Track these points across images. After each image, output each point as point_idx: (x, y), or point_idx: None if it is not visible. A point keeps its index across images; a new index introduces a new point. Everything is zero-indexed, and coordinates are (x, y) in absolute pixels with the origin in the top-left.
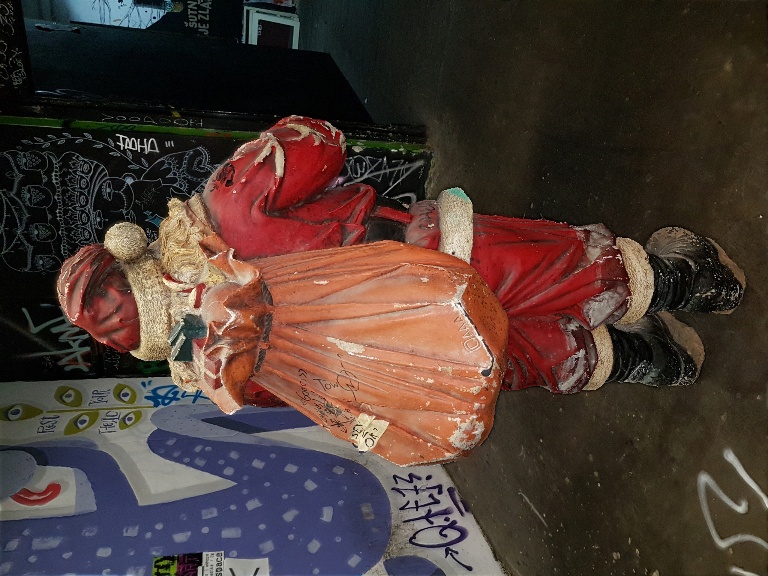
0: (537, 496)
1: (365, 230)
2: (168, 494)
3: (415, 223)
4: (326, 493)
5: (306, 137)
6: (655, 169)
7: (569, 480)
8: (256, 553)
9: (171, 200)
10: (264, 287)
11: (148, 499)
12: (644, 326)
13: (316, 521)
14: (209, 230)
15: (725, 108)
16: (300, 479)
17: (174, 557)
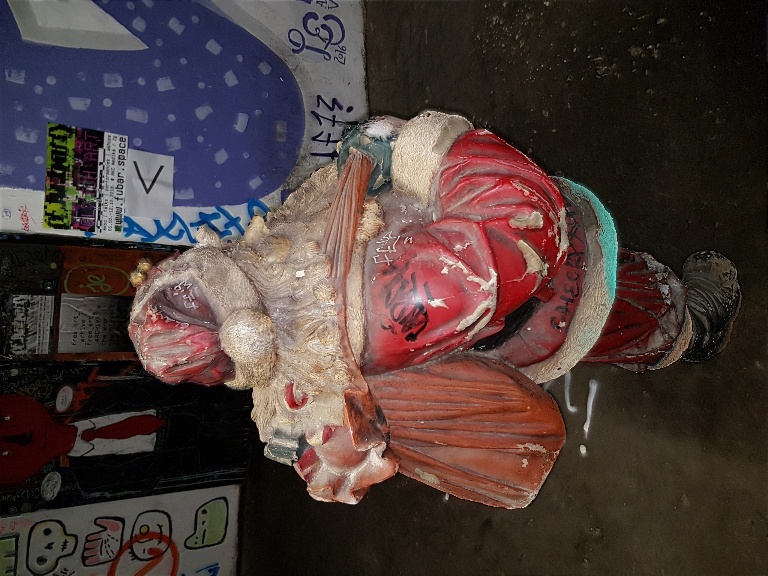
0: None
1: None
2: (60, 33)
3: (550, 309)
4: (246, 96)
5: (529, 275)
6: None
7: None
8: (162, 148)
9: (323, 296)
10: None
11: (34, 33)
12: None
13: (229, 128)
14: (361, 377)
15: None
16: (222, 67)
17: (72, 130)
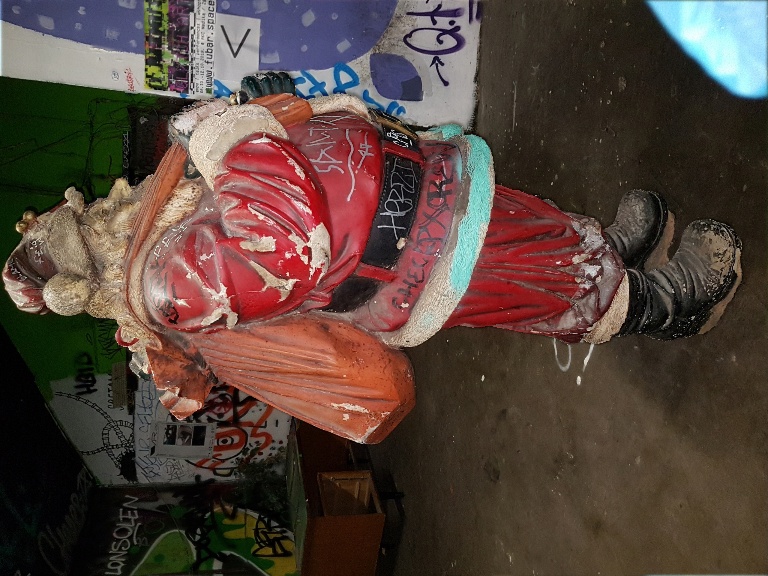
0: (521, 109)
1: (330, 301)
2: None
3: (393, 290)
4: None
5: (271, 288)
6: None
7: (543, 145)
8: (249, 10)
9: (107, 276)
10: (210, 376)
11: None
12: (631, 246)
13: None
14: (155, 337)
15: None
16: None
17: None
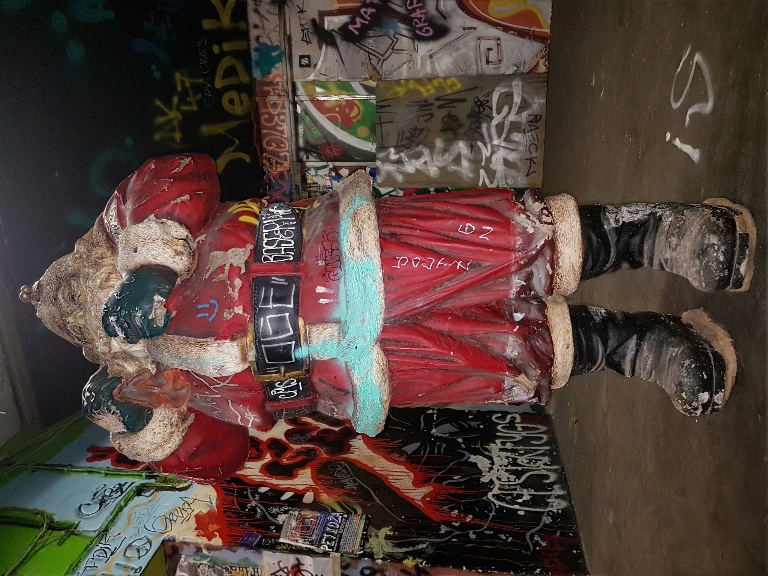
0: None
1: None
2: None
3: None
4: None
5: None
6: (763, 534)
7: None
8: None
9: None
10: None
11: None
12: None
13: None
14: None
15: (720, 571)
16: None
17: None
